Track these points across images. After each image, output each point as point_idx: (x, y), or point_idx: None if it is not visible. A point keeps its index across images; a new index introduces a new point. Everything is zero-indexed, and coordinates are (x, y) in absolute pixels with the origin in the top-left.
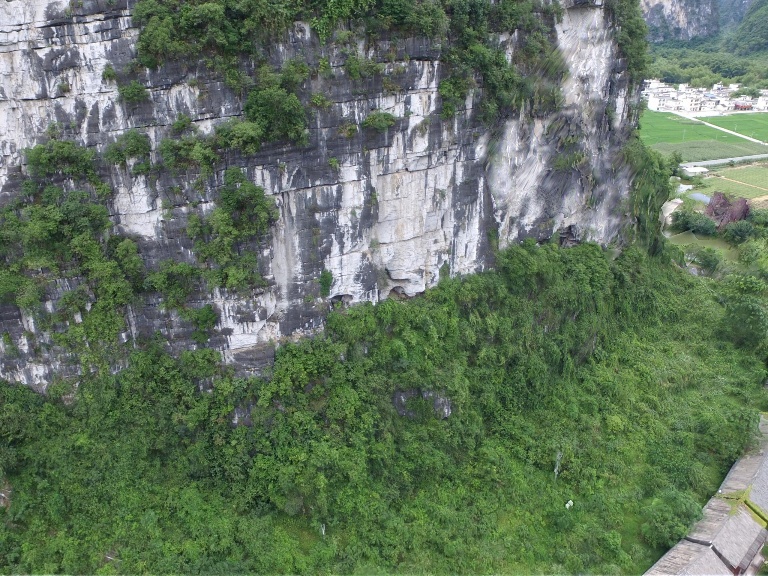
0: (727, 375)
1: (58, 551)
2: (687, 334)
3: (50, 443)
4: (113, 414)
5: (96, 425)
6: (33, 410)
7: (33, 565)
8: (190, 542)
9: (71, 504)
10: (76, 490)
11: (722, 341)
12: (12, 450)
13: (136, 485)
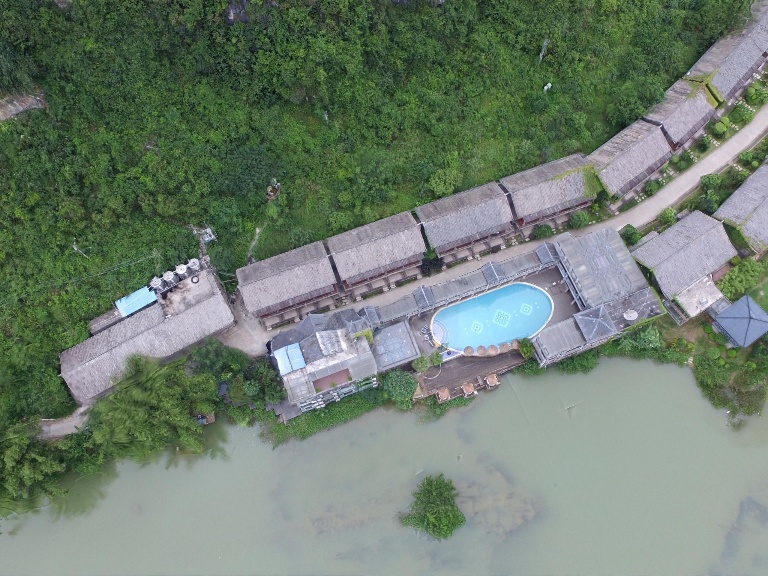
0: None
1: (105, 144)
2: None
3: (61, 49)
4: (111, 17)
5: (98, 29)
6: (32, 16)
7: (89, 156)
8: (213, 132)
9: (101, 104)
10: (101, 91)
11: None
12: (29, 57)
13: (153, 84)
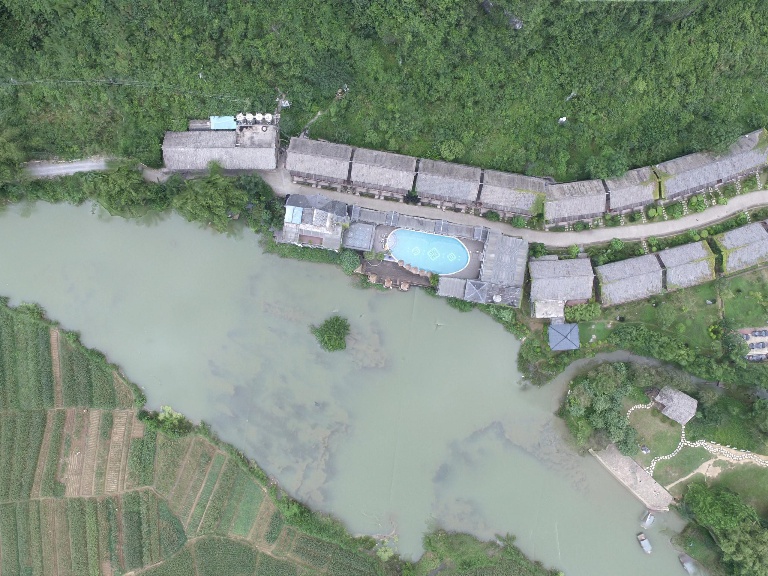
0: None
1: (247, 15)
2: None
3: None
4: None
5: None
6: None
7: (233, 20)
8: (319, 40)
9: None
10: None
11: None
12: None
13: None
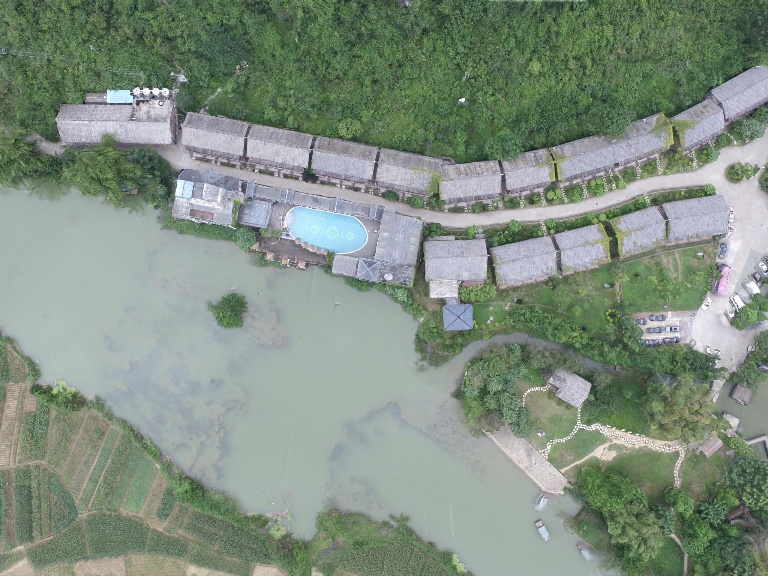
0: (699, 63)
1: None
2: (709, 8)
3: None
4: None
5: None
6: None
7: None
8: (211, 14)
9: None
10: None
11: (736, 30)
12: None
13: None
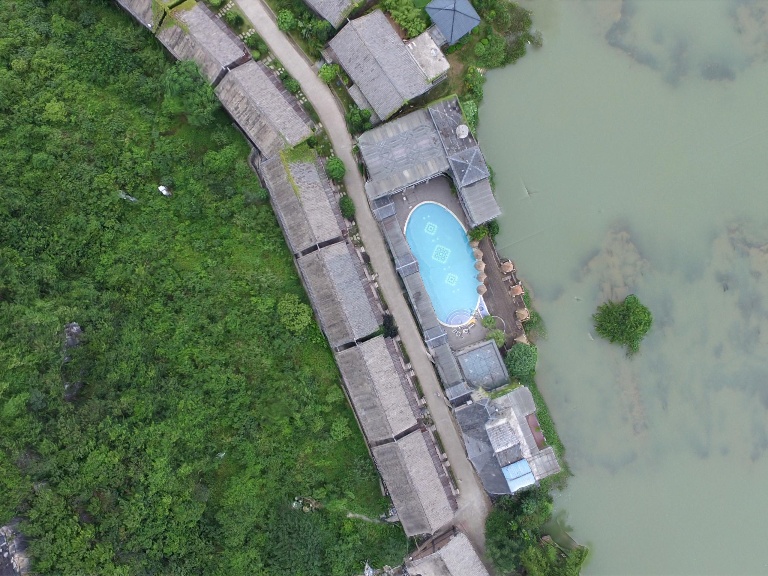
0: None
1: None
2: None
3: None
4: None
5: None
6: None
7: None
8: None
9: None
10: None
11: None
12: None
13: None
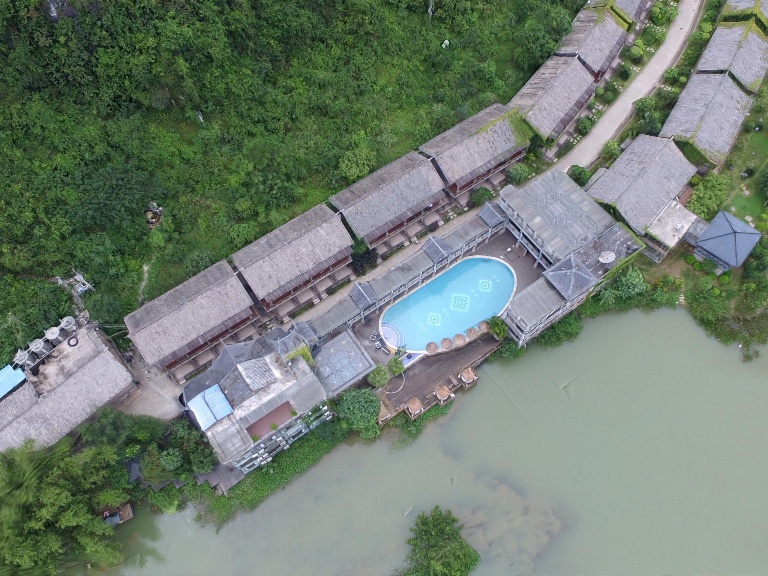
0: None
1: None
2: None
3: None
4: None
5: None
6: None
7: None
8: (60, 156)
9: None
10: None
11: None
12: None
13: None
